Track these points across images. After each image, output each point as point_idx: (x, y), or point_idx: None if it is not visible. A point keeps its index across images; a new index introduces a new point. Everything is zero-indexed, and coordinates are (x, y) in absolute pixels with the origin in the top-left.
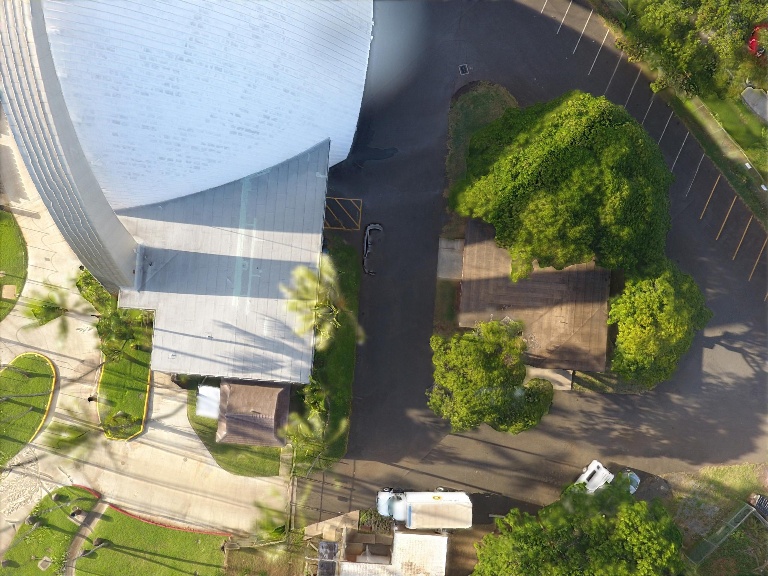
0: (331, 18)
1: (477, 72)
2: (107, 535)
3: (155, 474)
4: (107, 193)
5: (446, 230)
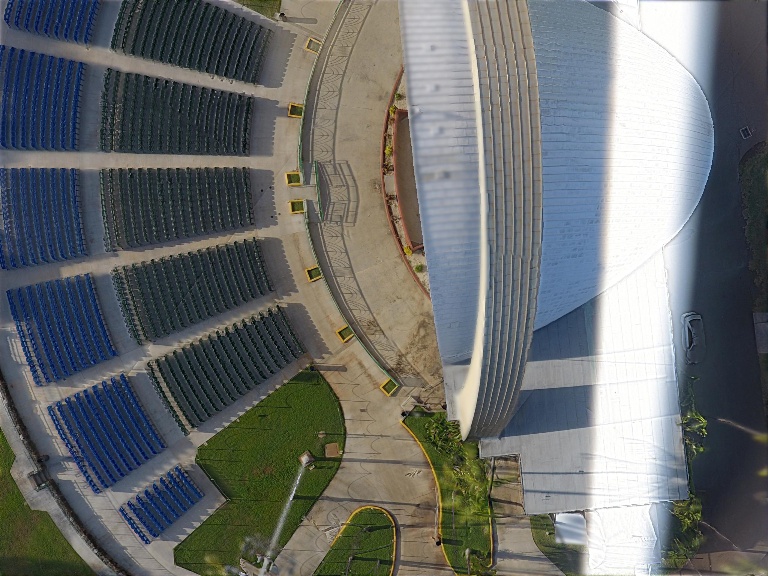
0: (694, 134)
1: (760, 133)
2: None
3: None
4: (470, 352)
5: (759, 304)
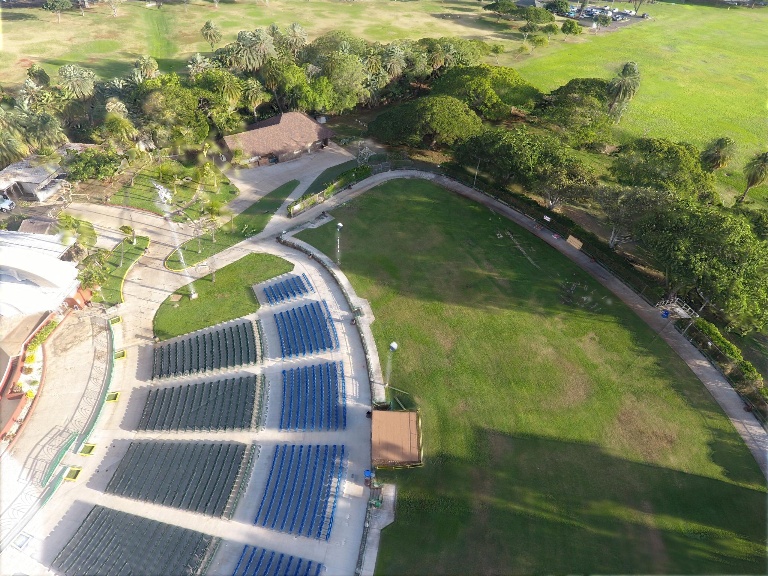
0: None
1: None
2: (168, 207)
3: (130, 224)
4: None
5: None
